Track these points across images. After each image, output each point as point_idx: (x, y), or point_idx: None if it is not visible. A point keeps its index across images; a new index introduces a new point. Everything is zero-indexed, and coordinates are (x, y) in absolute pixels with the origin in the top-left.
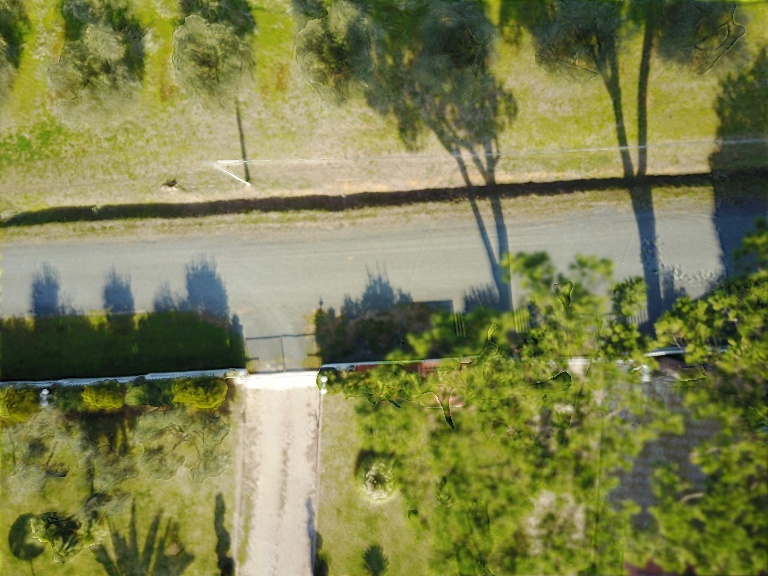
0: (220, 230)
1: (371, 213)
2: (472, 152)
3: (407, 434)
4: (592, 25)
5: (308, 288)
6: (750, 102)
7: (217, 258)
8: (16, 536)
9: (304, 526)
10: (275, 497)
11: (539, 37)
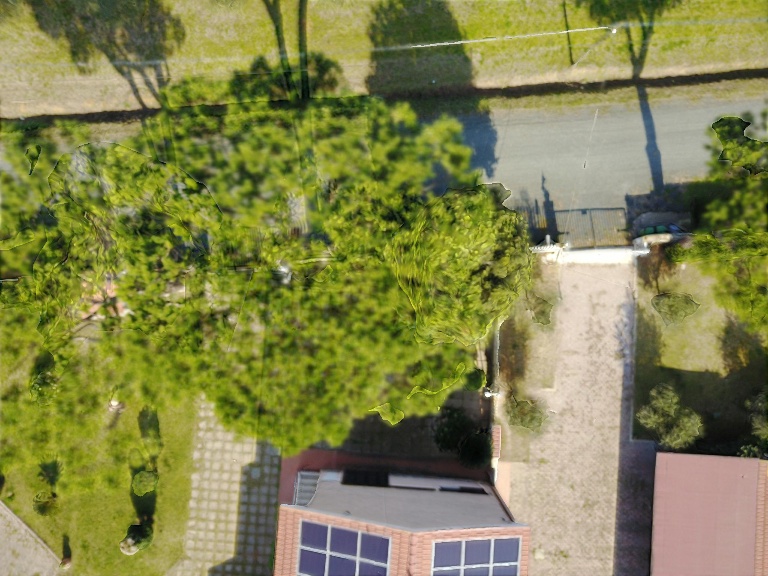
0: None
1: (44, 134)
2: (144, 75)
3: None
4: None
5: None
6: (400, 28)
7: None
8: None
9: None
10: None
11: None
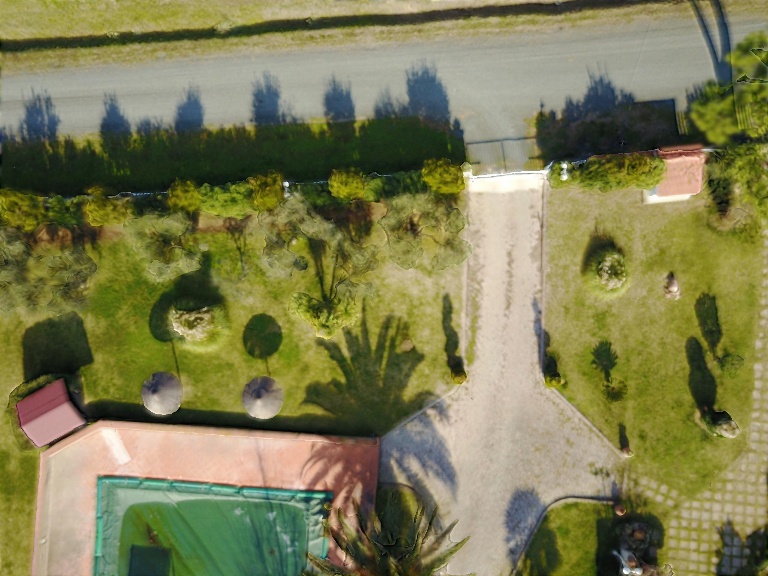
0: (439, 36)
1: (590, 16)
2: None
3: (632, 231)
4: None
5: (529, 91)
6: None
7: (437, 64)
8: (250, 336)
9: (530, 325)
10: (500, 298)
11: None
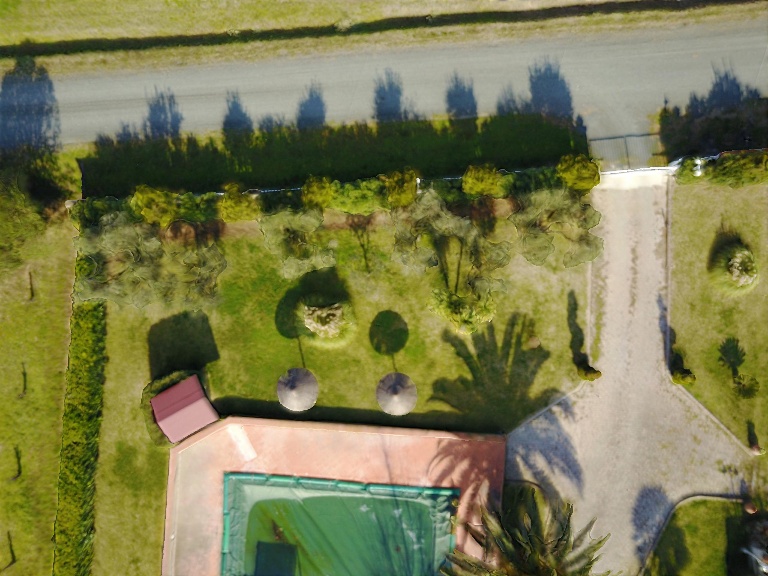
0: (561, 33)
1: (714, 12)
2: None
3: (759, 228)
4: None
5: (652, 87)
6: None
7: (559, 60)
8: (376, 332)
9: (655, 321)
10: (624, 294)
11: None
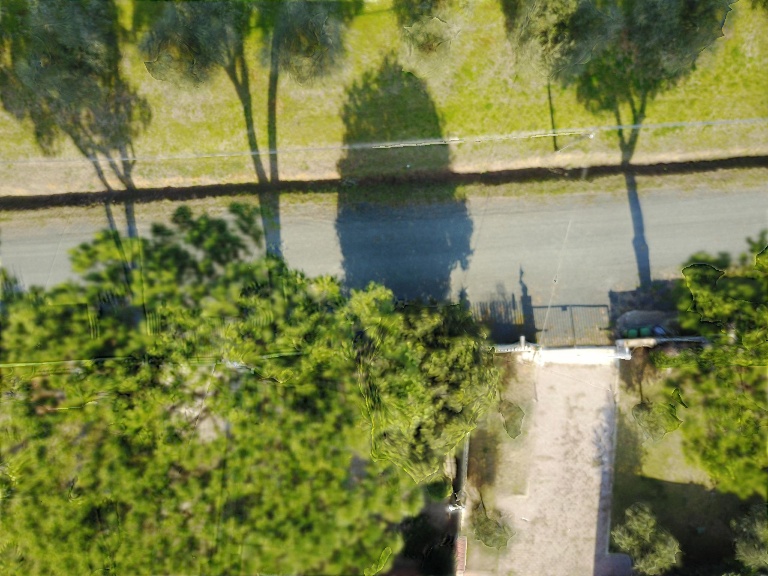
0: None
1: (8, 217)
2: (109, 157)
3: (42, 434)
4: (192, 33)
5: None
6: (374, 110)
7: None
8: None
9: None
10: None
11: (164, 43)
